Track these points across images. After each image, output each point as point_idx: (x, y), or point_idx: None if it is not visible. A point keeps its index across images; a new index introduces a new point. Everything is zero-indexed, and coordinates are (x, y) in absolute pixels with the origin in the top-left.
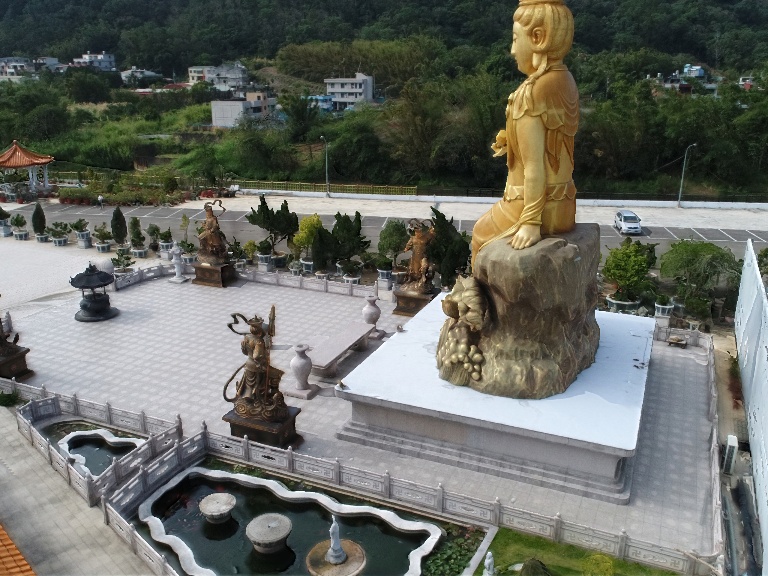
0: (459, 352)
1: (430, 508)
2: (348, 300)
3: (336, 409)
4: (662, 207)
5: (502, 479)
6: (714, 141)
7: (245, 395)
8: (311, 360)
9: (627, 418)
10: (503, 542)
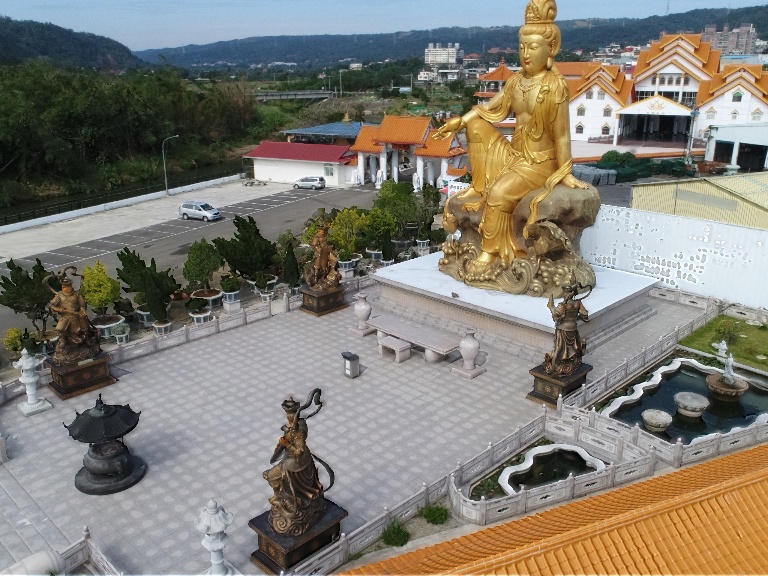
0: (568, 273)
1: (658, 356)
2: (257, 327)
3: (509, 363)
4: (157, 198)
5: (626, 333)
6: (42, 140)
7: (572, 354)
8: (449, 346)
9: (624, 273)
10: (691, 346)
